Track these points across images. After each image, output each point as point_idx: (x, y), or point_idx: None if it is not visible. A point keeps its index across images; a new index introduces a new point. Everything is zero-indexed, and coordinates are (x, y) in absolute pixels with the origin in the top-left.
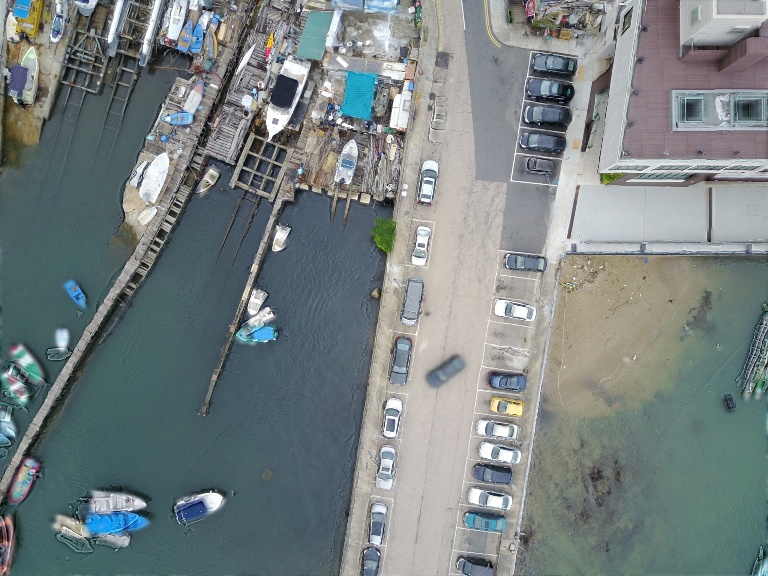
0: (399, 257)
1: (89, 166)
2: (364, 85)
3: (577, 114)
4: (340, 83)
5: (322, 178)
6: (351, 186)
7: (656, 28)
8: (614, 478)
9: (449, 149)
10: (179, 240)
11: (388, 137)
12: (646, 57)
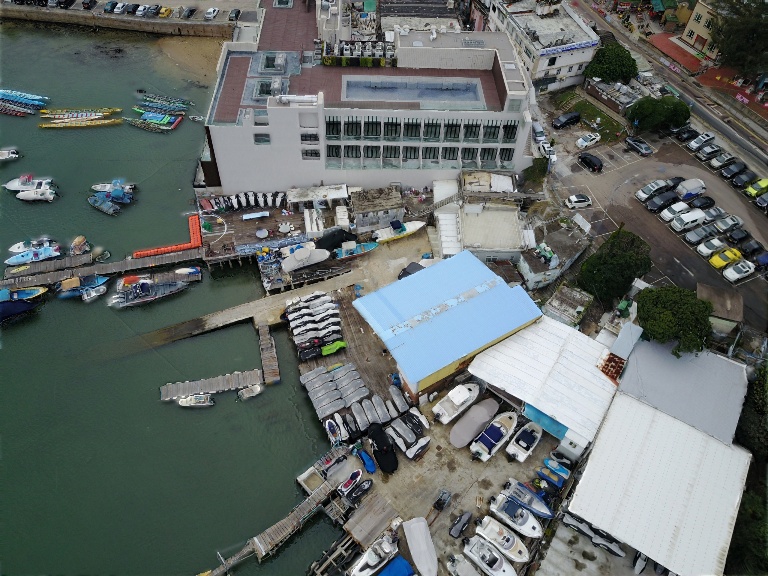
0: None
1: None
2: None
3: None
4: None
5: None
6: None
7: None
8: None
9: None
10: None
11: None
12: None
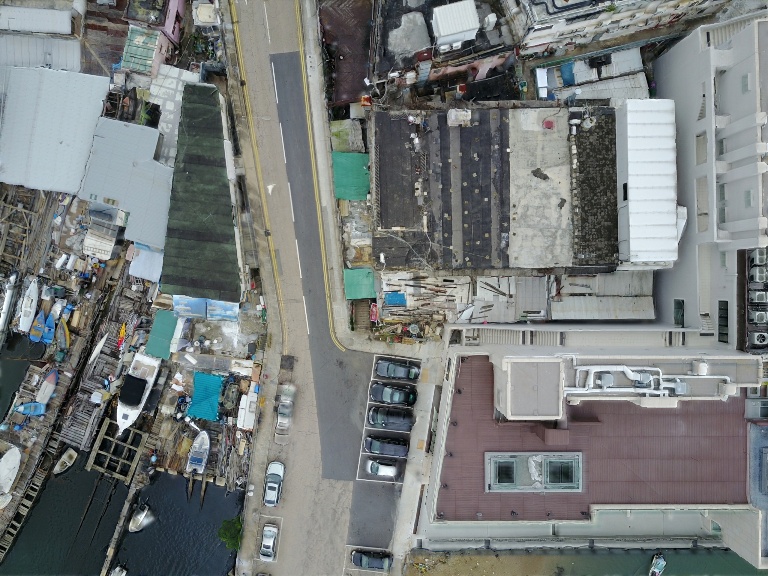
0: (248, 552)
1: None
2: (211, 385)
3: (421, 415)
4: (191, 374)
5: (177, 463)
6: (205, 471)
7: (470, 390)
8: None
9: (295, 449)
10: (40, 513)
11: (237, 432)
12: (460, 419)
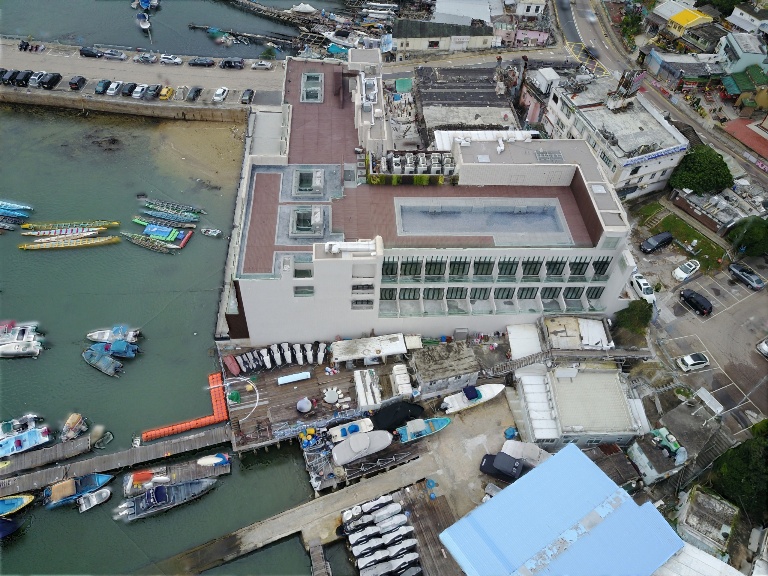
0: None
1: (313, 4)
2: None
3: None
4: None
5: None
6: None
7: None
8: (108, 148)
9: None
10: None
11: None
12: None
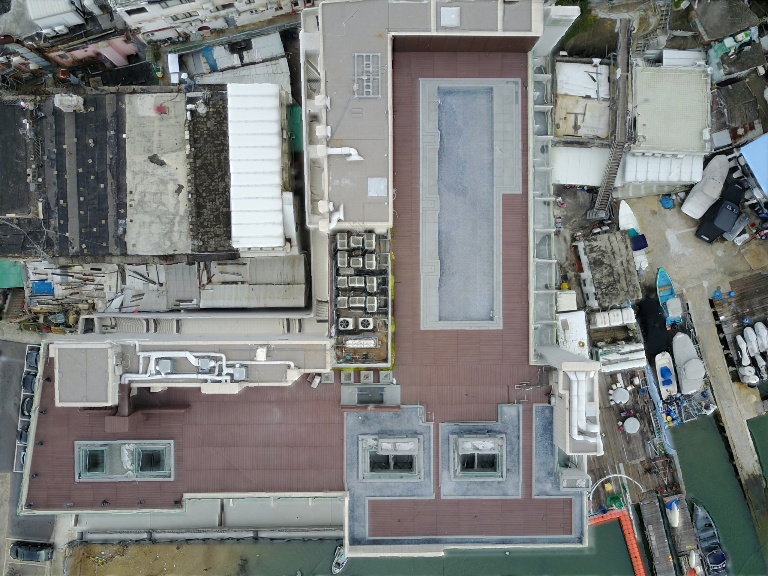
0: None
1: None
2: None
3: None
4: None
5: None
6: None
7: None
8: None
9: None
10: None
11: None
12: (50, 407)
